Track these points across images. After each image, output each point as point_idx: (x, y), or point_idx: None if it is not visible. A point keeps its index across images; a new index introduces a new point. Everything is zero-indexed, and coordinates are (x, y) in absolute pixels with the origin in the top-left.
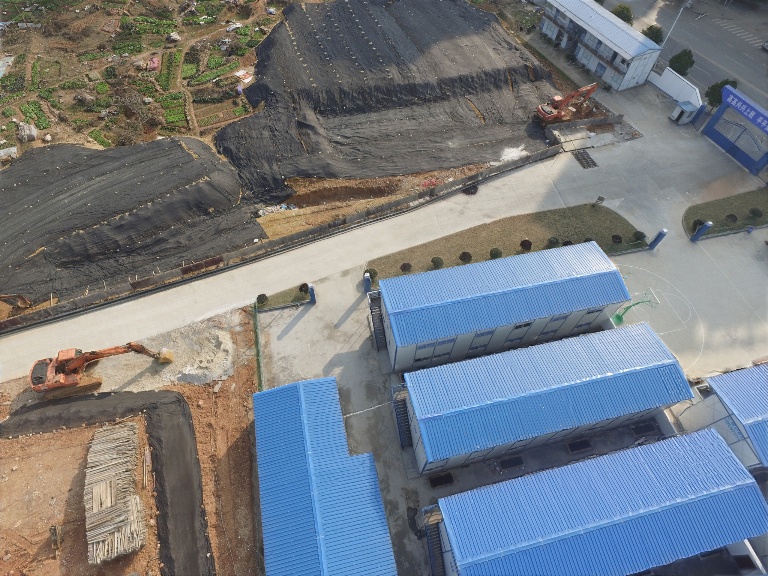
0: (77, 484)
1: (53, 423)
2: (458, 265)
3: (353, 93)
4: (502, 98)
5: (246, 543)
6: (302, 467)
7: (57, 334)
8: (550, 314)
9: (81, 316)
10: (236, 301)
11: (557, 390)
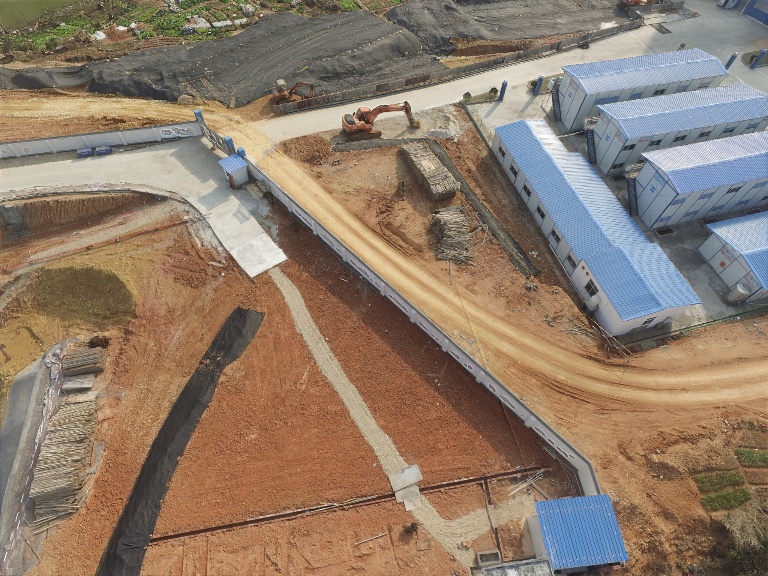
0: (399, 171)
1: (368, 145)
2: None
3: None
4: None
5: (508, 206)
6: (543, 155)
7: (338, 112)
8: (679, 80)
9: (348, 104)
10: (446, 101)
11: (697, 108)
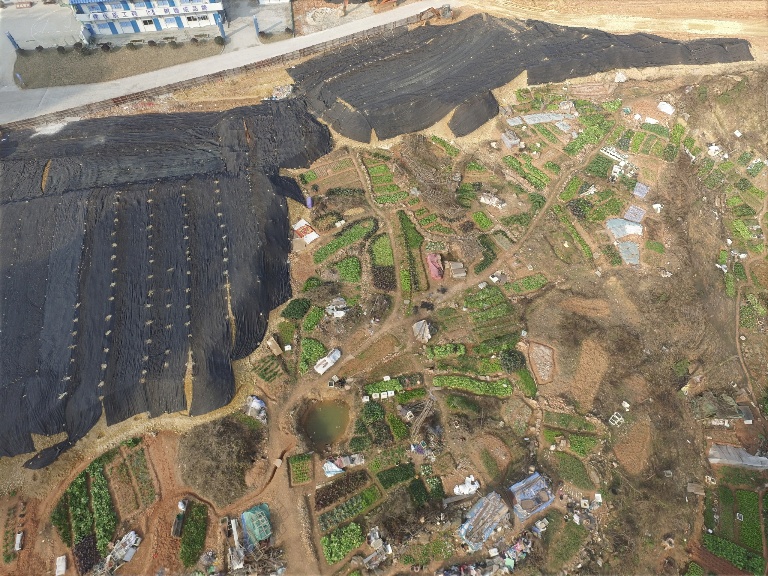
0: None
1: None
2: (160, 47)
3: (175, 180)
4: (1, 191)
5: None
6: None
7: None
8: None
9: None
10: (306, 38)
11: None
